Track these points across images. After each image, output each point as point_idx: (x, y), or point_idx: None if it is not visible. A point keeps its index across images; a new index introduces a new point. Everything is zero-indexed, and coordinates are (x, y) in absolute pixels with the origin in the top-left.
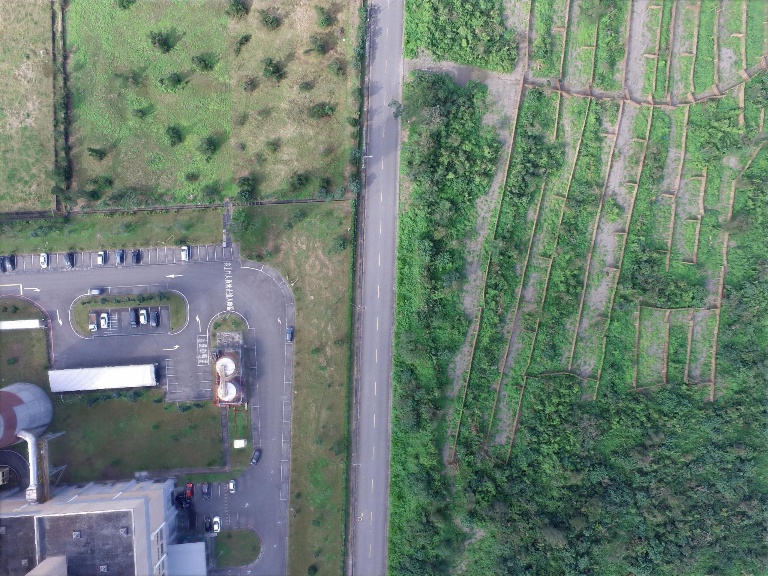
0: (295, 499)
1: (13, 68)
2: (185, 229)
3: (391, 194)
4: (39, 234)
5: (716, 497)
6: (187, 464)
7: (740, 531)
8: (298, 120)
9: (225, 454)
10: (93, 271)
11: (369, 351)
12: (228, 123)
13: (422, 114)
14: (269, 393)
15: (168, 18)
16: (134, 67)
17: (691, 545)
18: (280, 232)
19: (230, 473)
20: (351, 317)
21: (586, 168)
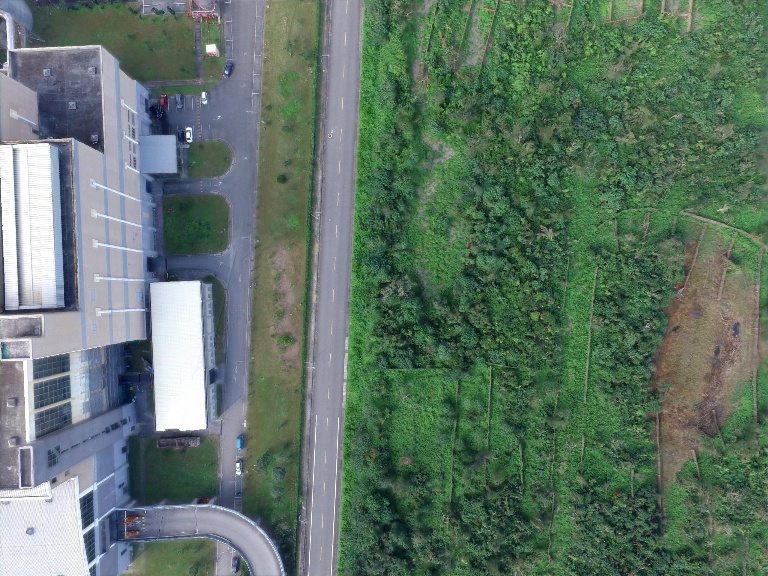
0: (266, 112)
1: None
2: None
3: None
4: None
5: (692, 129)
6: (161, 76)
7: (716, 162)
8: None
9: (198, 67)
10: None
11: None
12: None
13: None
14: (242, 8)
15: None
16: None
17: (665, 171)
18: None
19: (203, 86)
20: None
21: None
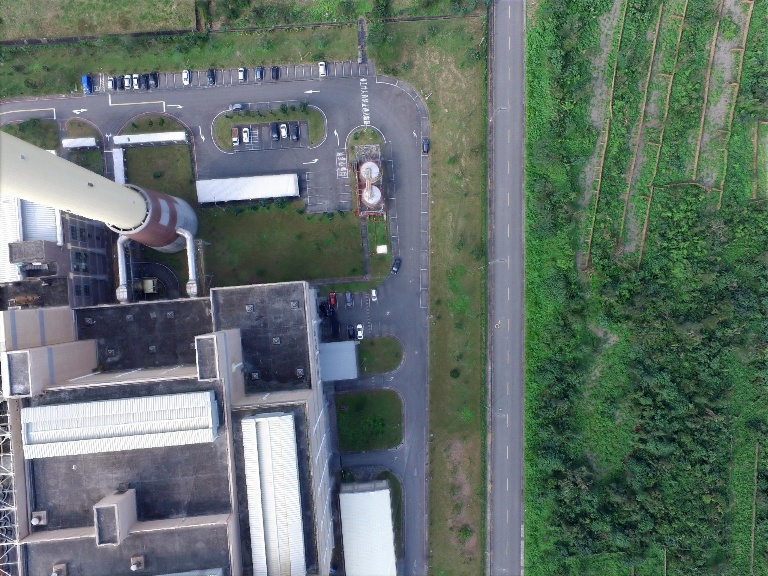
0: (435, 306)
1: None
2: (322, 45)
3: (518, 11)
4: (182, 51)
5: None
6: (329, 274)
7: None
8: None
9: (366, 264)
10: (233, 88)
11: (501, 163)
12: None
13: None
14: (407, 204)
15: None
16: None
17: None
18: (413, 48)
19: (371, 282)
20: (485, 128)
21: None
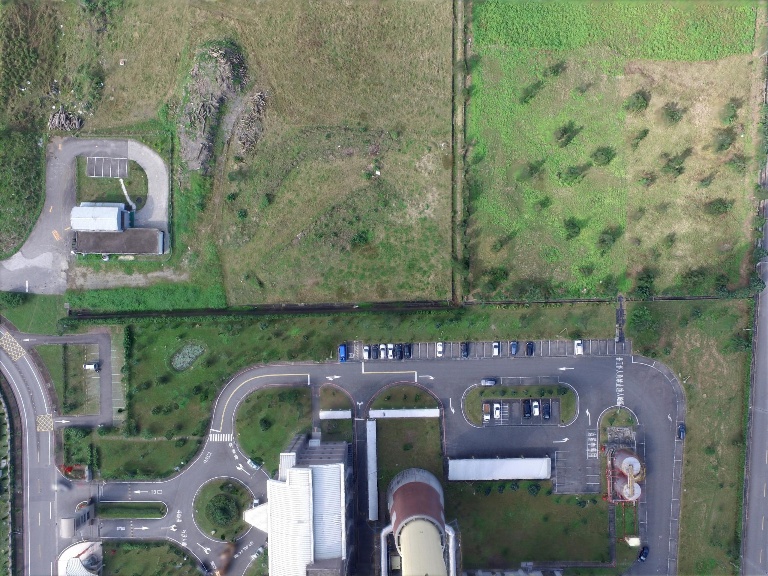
0: None
1: (414, 160)
2: None
3: None
4: None
5: None
6: (573, 557)
7: None
8: (694, 216)
9: (611, 549)
10: (486, 361)
11: (759, 452)
12: (623, 218)
13: None
14: (657, 490)
15: (566, 112)
16: (532, 161)
17: None
18: (673, 328)
19: (616, 568)
20: (746, 418)
21: None
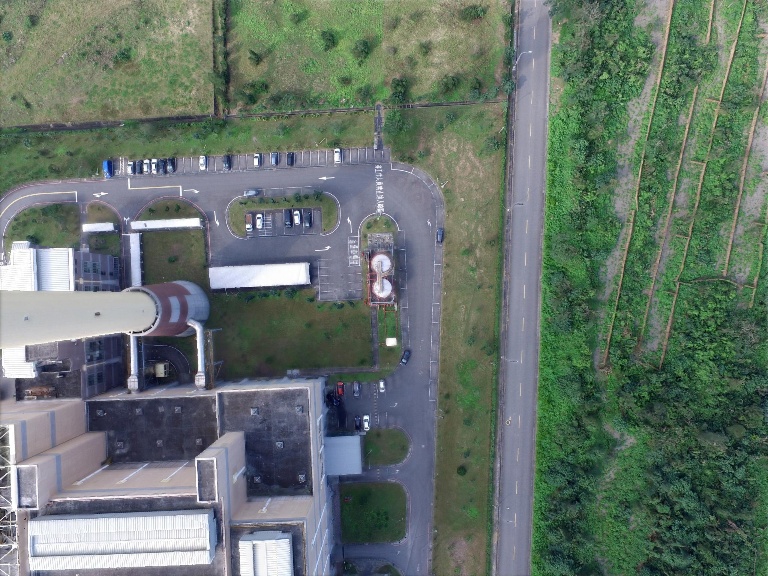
0: (444, 400)
1: None
2: (338, 131)
3: (541, 96)
4: (199, 137)
5: None
6: (338, 363)
7: None
8: (449, 23)
9: (375, 354)
10: (249, 173)
11: (518, 254)
12: (380, 27)
13: (579, 11)
14: (418, 294)
15: None
16: None
17: None
18: (430, 135)
19: (379, 373)
20: (502, 218)
21: (742, 70)
